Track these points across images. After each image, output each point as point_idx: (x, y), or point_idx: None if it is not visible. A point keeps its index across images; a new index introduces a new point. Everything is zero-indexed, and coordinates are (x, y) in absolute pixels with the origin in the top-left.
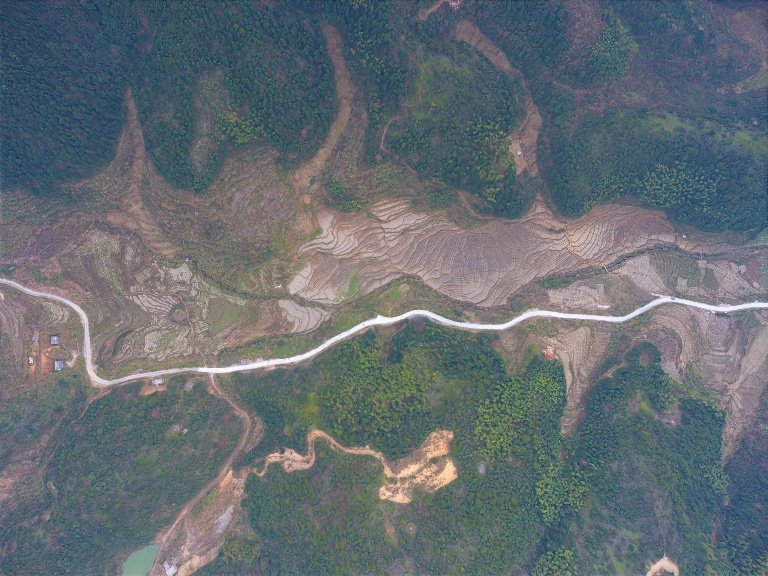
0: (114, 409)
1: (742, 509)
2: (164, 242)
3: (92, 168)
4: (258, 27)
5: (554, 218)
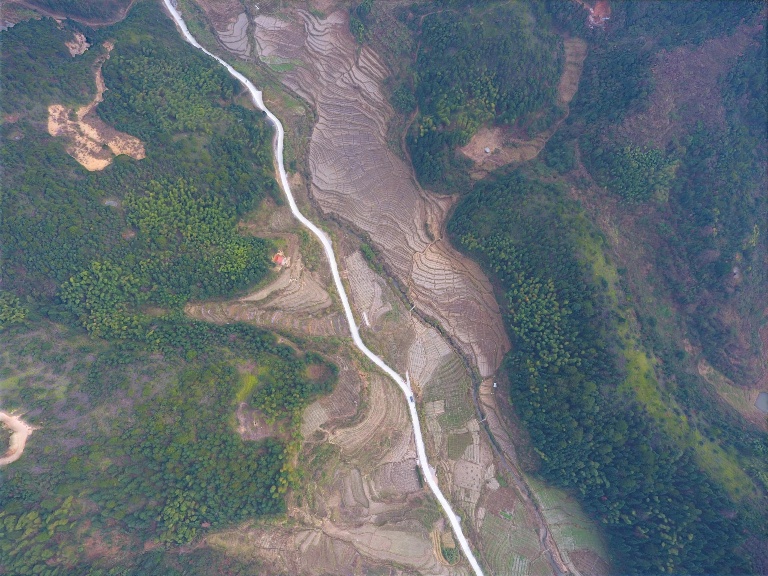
0: None
1: None
2: None
3: None
4: None
5: (441, 223)
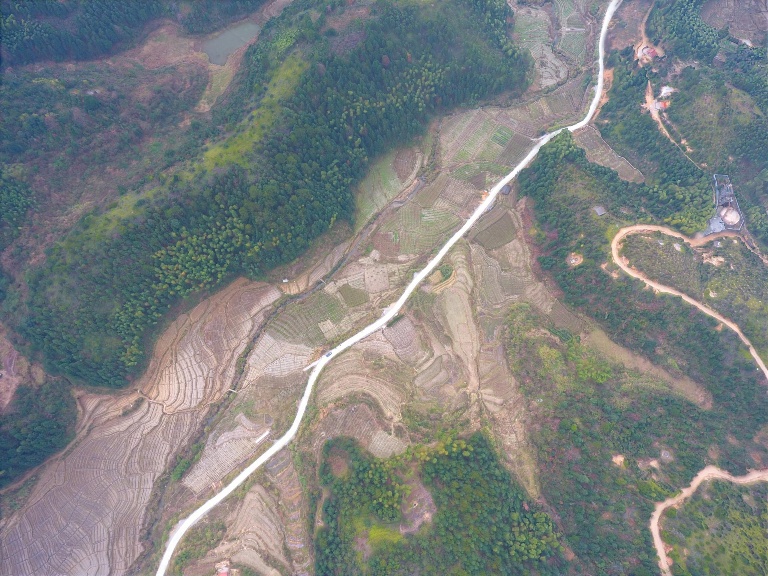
0: None
1: (595, 538)
2: None
3: None
4: None
5: (117, 398)
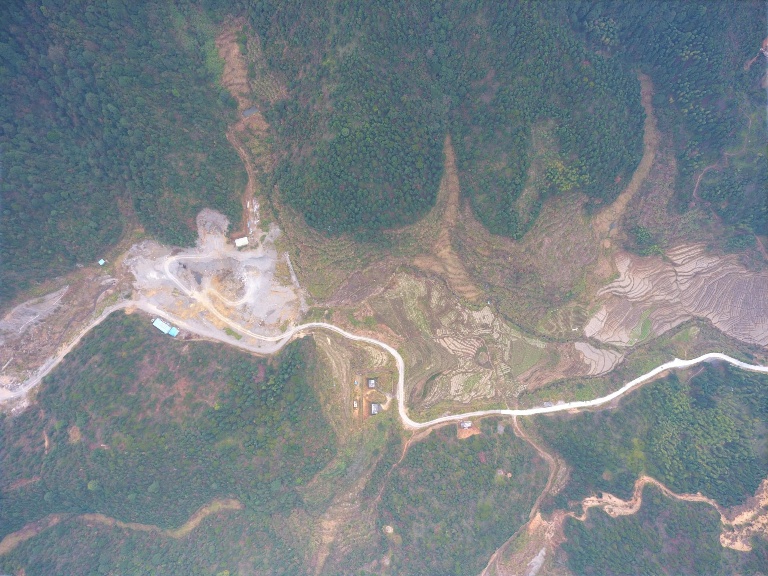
0: (441, 453)
1: None
2: (468, 285)
3: (417, 215)
4: (604, 80)
5: None
